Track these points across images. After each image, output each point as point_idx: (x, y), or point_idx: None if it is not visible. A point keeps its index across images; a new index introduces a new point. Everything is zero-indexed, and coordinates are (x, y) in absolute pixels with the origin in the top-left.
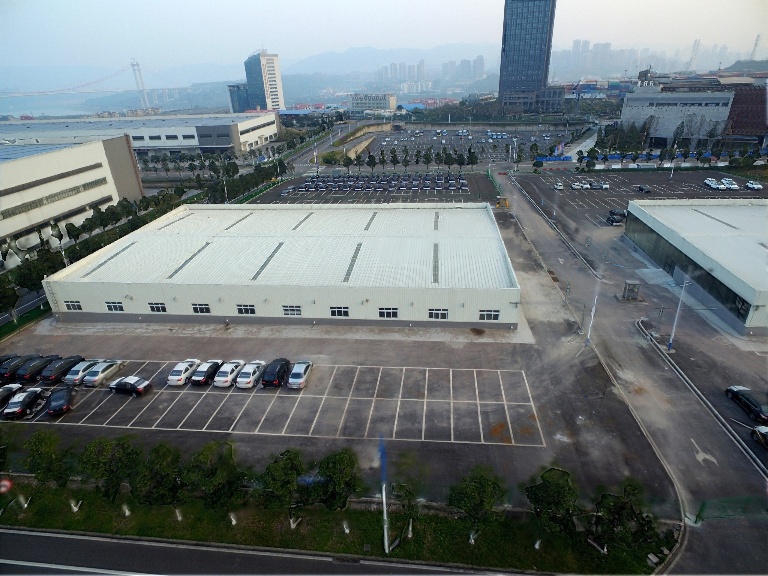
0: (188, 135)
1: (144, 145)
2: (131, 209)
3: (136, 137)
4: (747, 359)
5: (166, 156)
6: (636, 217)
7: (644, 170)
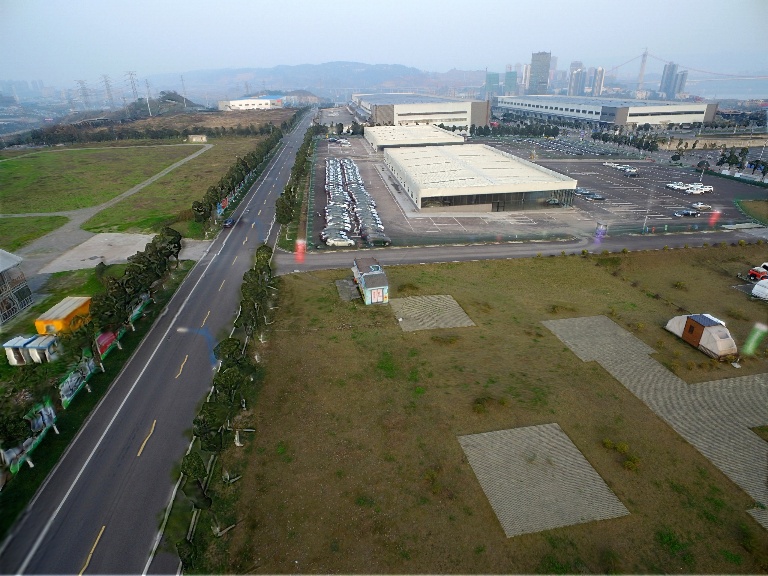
0: (598, 112)
1: (578, 116)
2: None
3: (578, 110)
4: (370, 163)
5: (557, 121)
6: None
7: (740, 180)
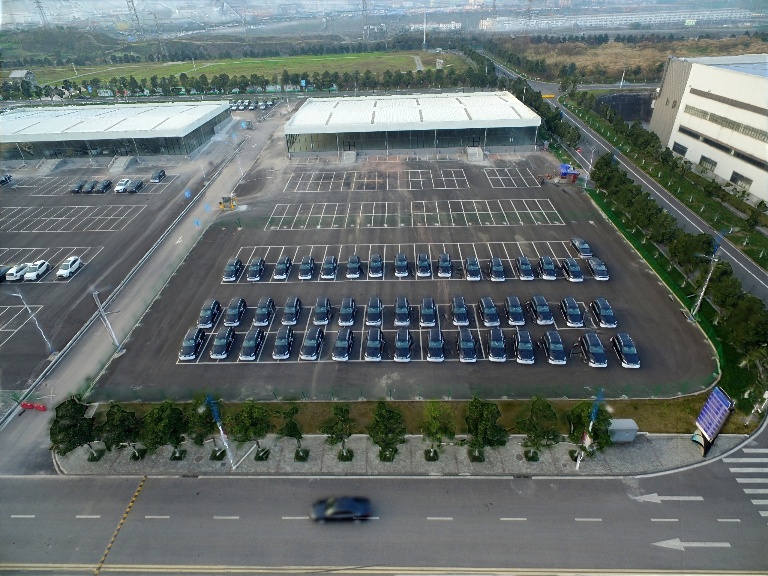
0: None
1: None
2: (641, 143)
3: None
4: None
5: None
6: (190, 133)
7: None
